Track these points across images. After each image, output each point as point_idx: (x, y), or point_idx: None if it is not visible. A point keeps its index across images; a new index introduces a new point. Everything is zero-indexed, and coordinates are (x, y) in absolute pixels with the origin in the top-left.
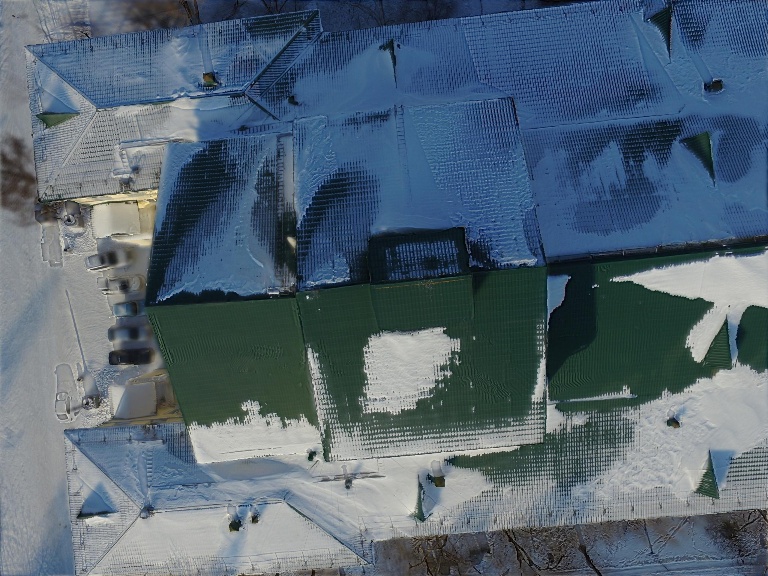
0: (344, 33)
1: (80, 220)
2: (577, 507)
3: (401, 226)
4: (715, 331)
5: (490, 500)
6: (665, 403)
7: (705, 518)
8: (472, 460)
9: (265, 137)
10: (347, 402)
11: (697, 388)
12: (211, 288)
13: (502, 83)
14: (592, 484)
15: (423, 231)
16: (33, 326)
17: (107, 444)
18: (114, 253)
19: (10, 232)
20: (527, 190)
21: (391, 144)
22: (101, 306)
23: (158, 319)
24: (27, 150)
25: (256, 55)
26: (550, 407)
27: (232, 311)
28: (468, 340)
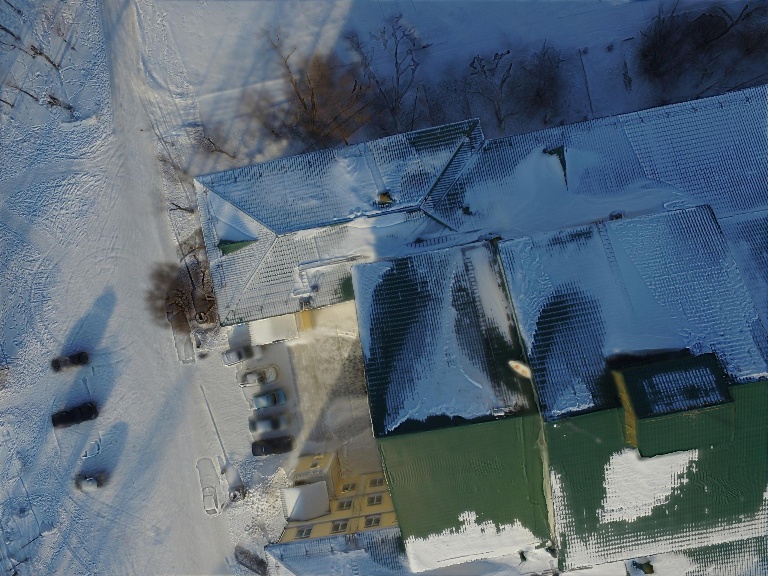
0: (506, 139)
1: (210, 316)
2: None
3: (636, 348)
4: None
5: None
6: None
7: None
8: None
9: (449, 251)
10: (585, 515)
11: None
12: (436, 414)
13: (669, 177)
14: None
15: (657, 351)
16: (171, 423)
17: (310, 557)
18: (249, 347)
19: (140, 333)
20: (748, 300)
21: (602, 262)
22: (237, 398)
23: (383, 446)
24: (150, 252)
25: (425, 169)
26: None
27: None
28: (705, 449)
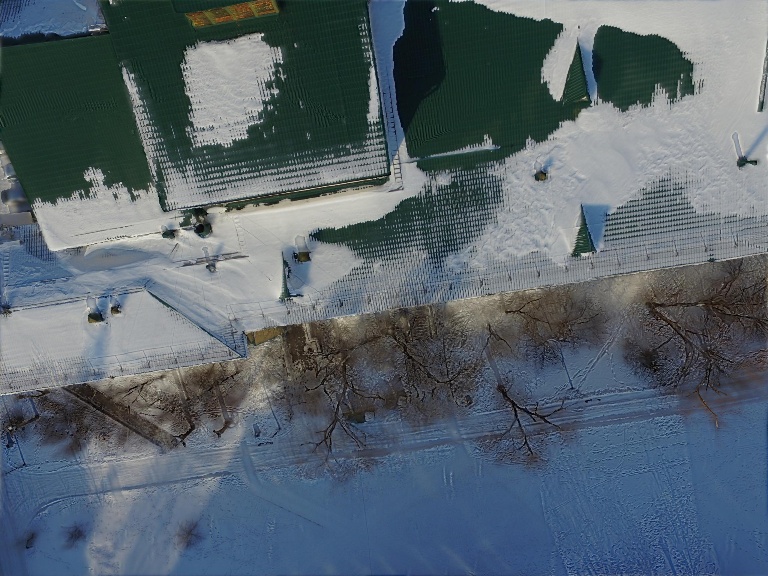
0: None
1: None
2: (452, 280)
3: None
4: (569, 59)
5: (361, 278)
6: (530, 154)
7: (624, 348)
8: (338, 233)
9: None
10: (174, 134)
11: (561, 133)
12: (30, 31)
13: None
14: (465, 253)
15: None
16: None
17: None
18: None
19: None
20: None
21: None
22: None
23: None
24: None
25: None
26: (411, 166)
27: (57, 59)
28: (289, 48)
